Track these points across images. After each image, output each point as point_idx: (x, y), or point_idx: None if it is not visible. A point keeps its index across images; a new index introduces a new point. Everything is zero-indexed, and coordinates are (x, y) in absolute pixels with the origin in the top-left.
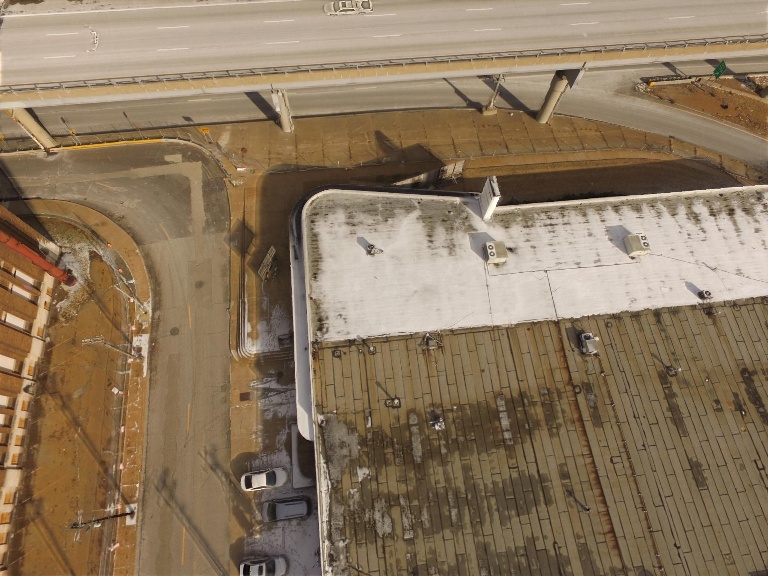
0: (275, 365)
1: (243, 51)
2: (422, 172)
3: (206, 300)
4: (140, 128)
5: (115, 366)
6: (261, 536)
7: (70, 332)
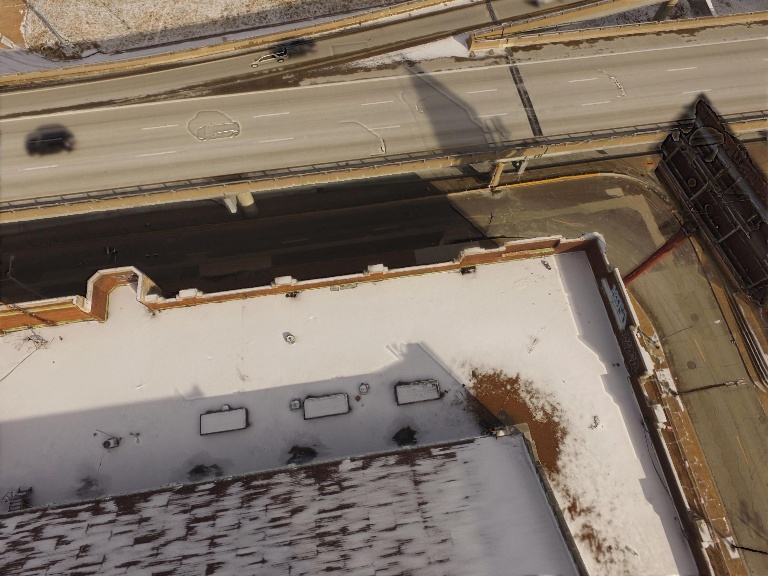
0: None
1: (765, 91)
2: None
3: (708, 333)
4: (561, 162)
5: None
6: None
7: None
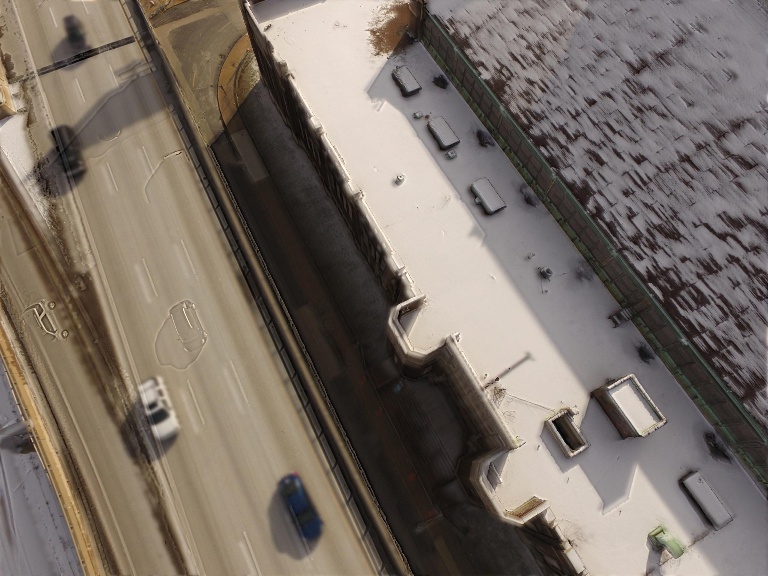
0: None
1: None
2: None
3: None
4: None
5: None
6: None
7: None
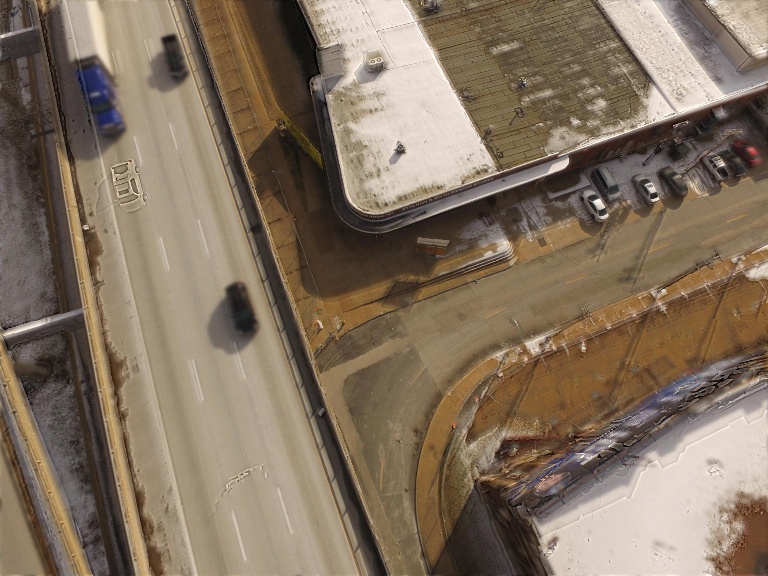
0: (509, 227)
1: (227, 275)
2: (283, 152)
3: (475, 305)
4: None
5: (565, 360)
6: (628, 199)
7: (555, 418)
